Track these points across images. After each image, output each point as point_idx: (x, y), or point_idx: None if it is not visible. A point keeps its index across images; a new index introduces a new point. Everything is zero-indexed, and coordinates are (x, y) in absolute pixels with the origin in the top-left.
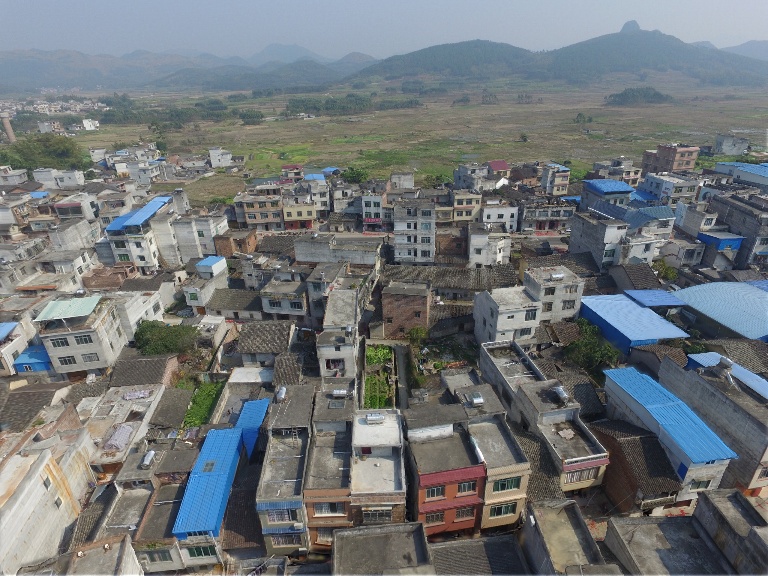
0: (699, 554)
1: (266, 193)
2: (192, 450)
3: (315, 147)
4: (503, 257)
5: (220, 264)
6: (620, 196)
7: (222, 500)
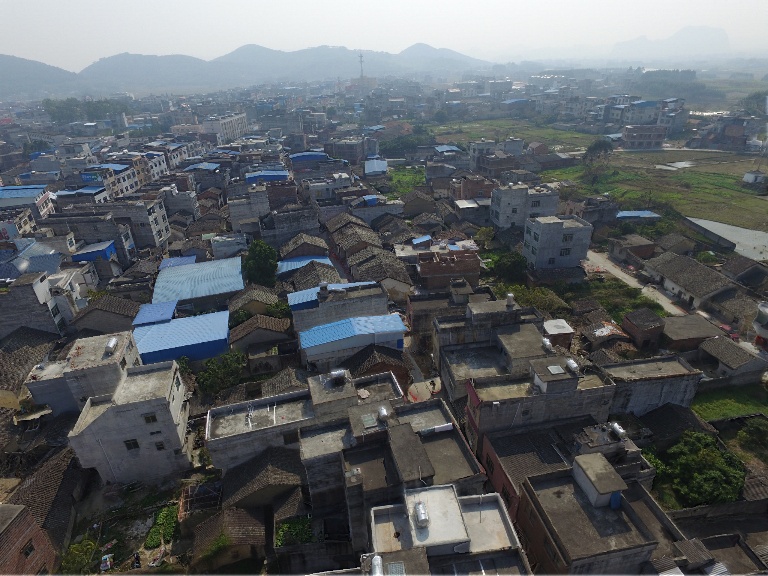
0: (465, 354)
1: None
2: None
3: None
4: None
5: None
6: None
7: None
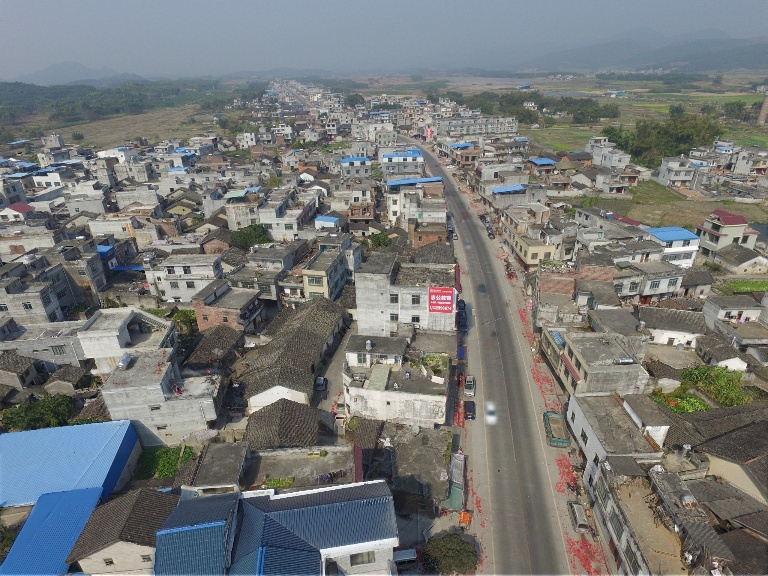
0: None
1: (534, 213)
2: (99, 242)
3: None
4: None
5: (326, 224)
6: None
7: None
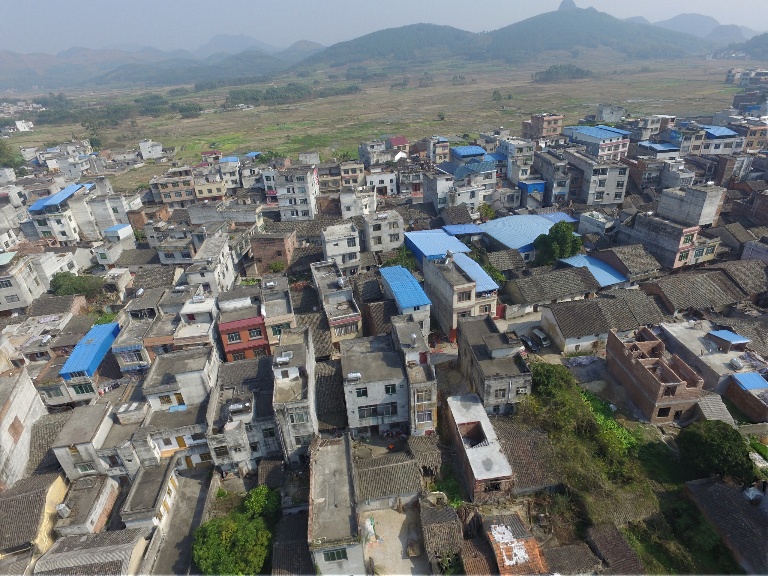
0: None
1: (179, 175)
2: (78, 334)
3: (247, 135)
4: (370, 212)
5: (126, 230)
6: (475, 158)
7: (95, 356)
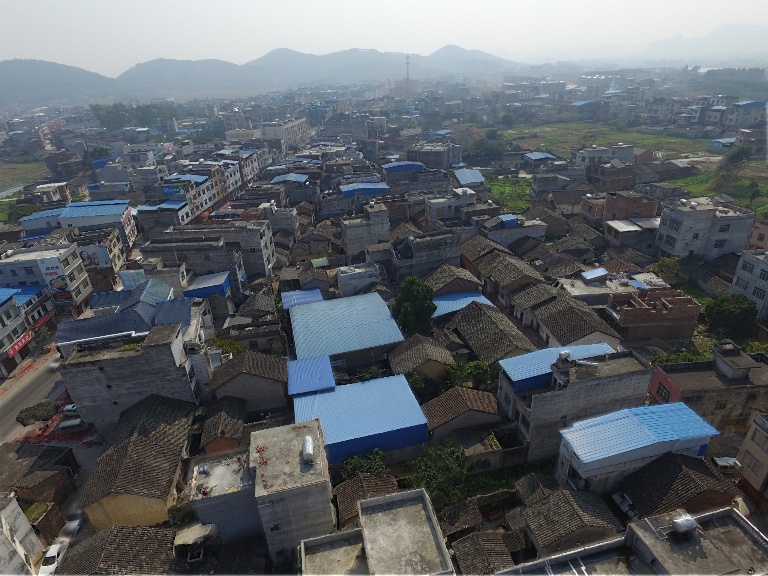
0: None
1: None
2: None
3: None
4: (21, 543)
5: None
6: (5, 308)
7: None
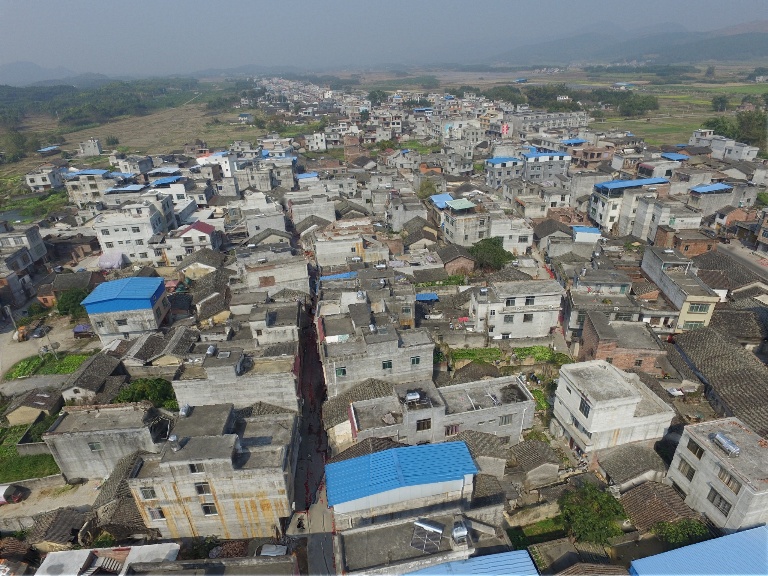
0: None
1: None
2: None
3: None
4: None
5: (590, 236)
6: None
7: None
